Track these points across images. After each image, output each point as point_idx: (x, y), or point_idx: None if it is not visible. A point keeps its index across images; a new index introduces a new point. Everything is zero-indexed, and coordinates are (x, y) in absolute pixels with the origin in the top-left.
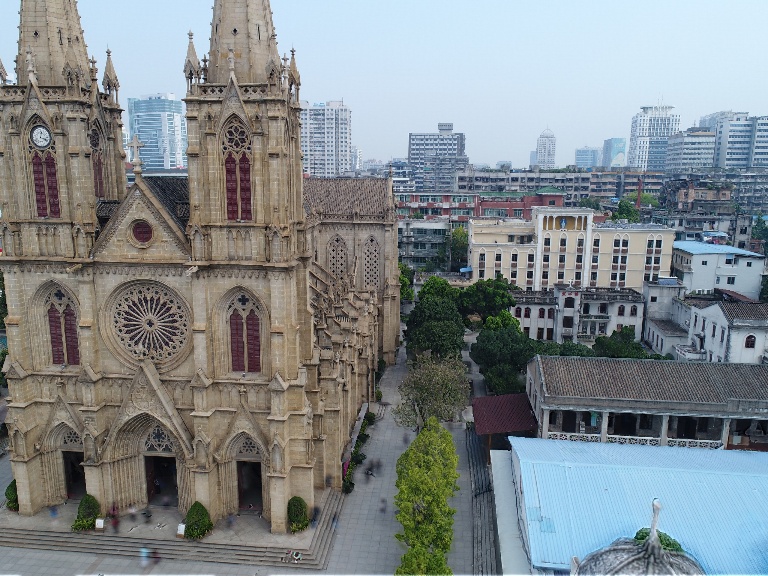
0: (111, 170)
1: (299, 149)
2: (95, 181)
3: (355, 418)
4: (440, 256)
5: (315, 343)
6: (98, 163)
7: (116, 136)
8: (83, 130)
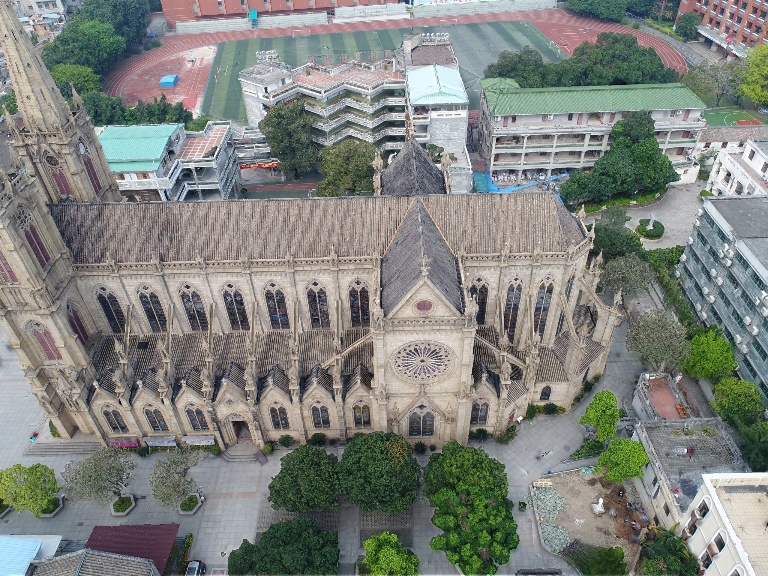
0: (69, 181)
1: (8, 244)
2: (61, 185)
3: (178, 434)
4: (761, 438)
5: (125, 364)
6: (61, 175)
7: (66, 160)
8: (28, 161)
